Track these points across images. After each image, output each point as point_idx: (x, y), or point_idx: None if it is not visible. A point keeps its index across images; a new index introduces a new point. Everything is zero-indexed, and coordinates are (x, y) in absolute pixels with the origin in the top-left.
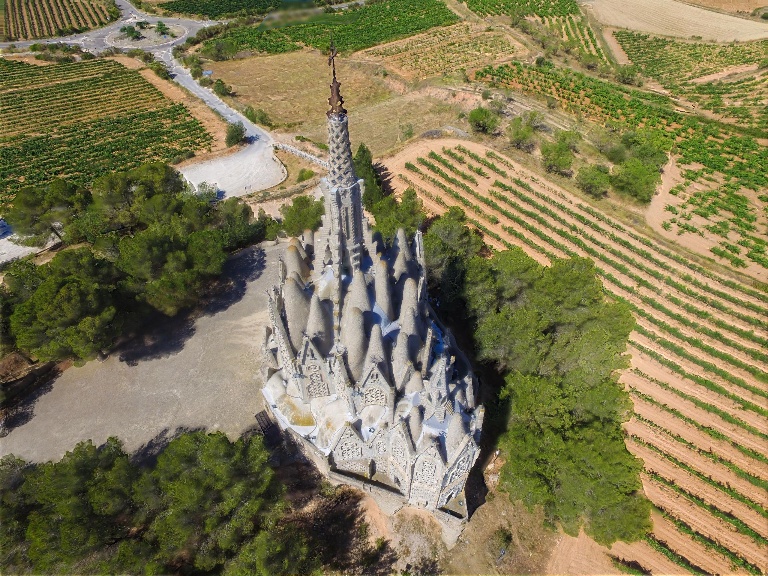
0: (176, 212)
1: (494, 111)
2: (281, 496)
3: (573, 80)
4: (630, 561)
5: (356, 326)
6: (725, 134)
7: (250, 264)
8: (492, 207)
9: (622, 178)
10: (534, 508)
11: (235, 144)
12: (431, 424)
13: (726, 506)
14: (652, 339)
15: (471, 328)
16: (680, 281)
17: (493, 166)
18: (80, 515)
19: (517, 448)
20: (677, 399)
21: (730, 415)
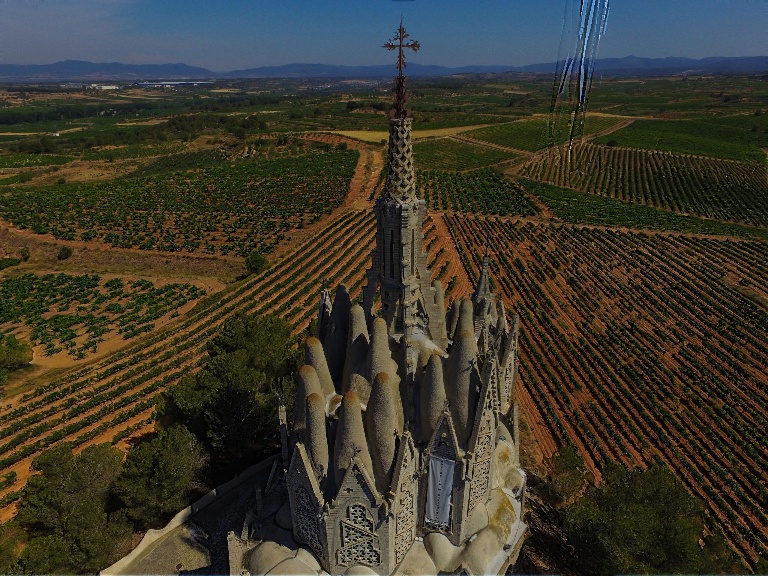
0: None
1: None
2: None
3: None
4: None
5: None
6: None
7: None
8: None
9: None
10: None
11: None
12: None
13: None
14: None
15: None
16: None
17: None
18: None
19: None
20: None
21: None
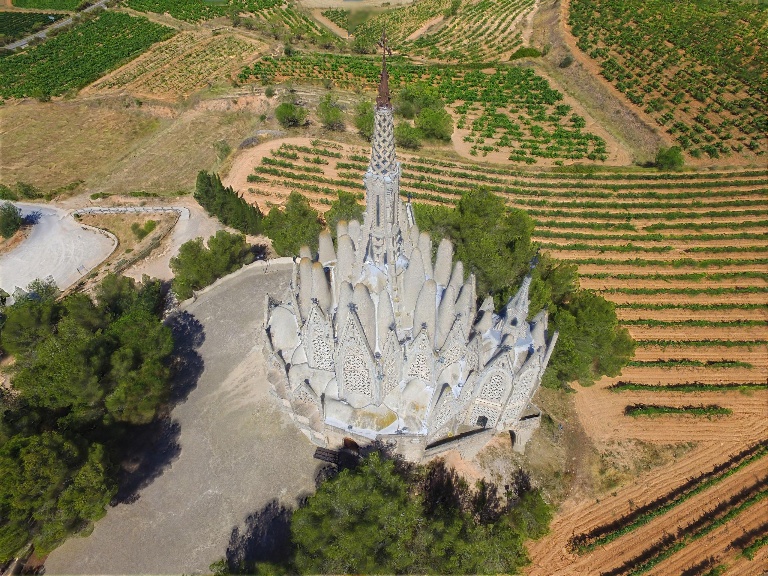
0: (53, 319)
1: None
2: (411, 494)
3: (326, 61)
4: (617, 384)
5: (433, 297)
6: (460, 73)
7: (183, 332)
8: (350, 186)
9: (426, 127)
10: (556, 385)
11: (16, 231)
12: (520, 344)
13: (636, 316)
14: None
15: None
16: (513, 187)
17: (326, 152)
18: None
19: None
20: None
21: (601, 259)
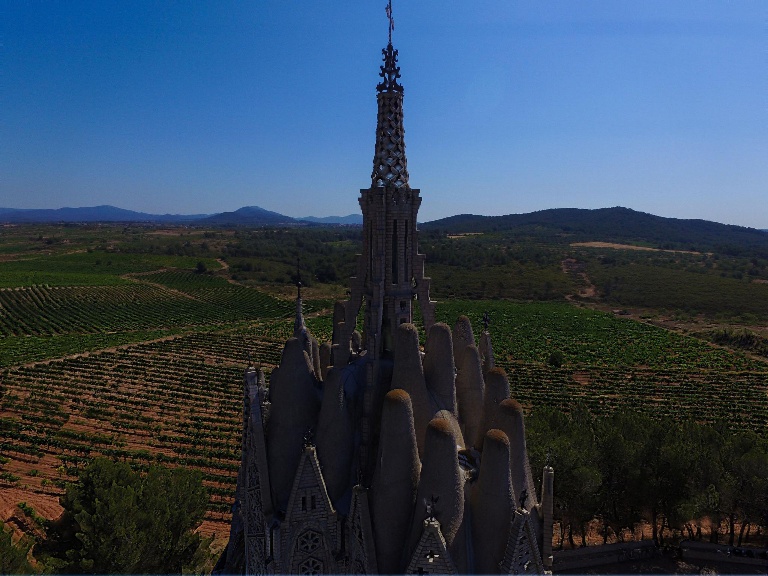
0: None
1: None
2: None
3: None
4: None
5: None
6: None
7: None
8: None
9: None
10: None
11: None
12: None
13: None
14: None
15: None
16: None
17: None
18: None
19: None
20: None
21: None
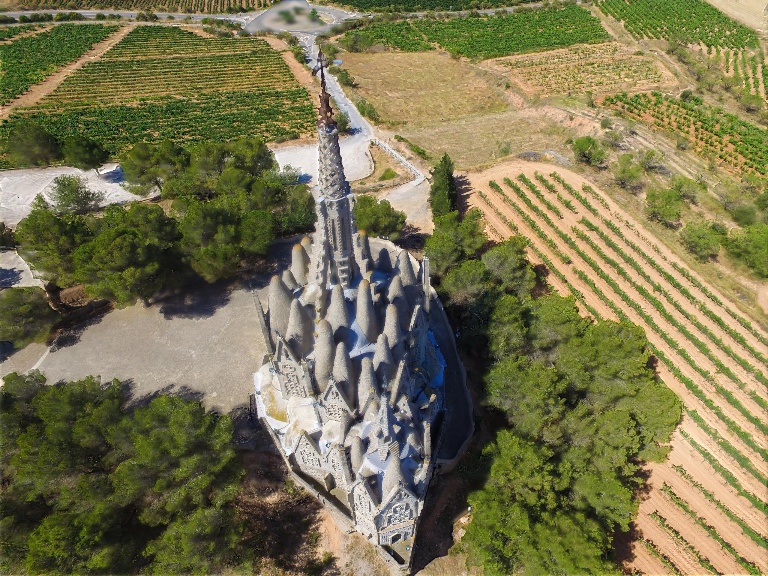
0: (248, 188)
1: (608, 142)
2: (237, 480)
3: (720, 122)
4: None
5: (323, 339)
6: None
7: None
8: (569, 245)
9: (740, 244)
10: None
11: None
12: (372, 459)
13: None
14: (713, 438)
15: (495, 368)
16: None
17: (585, 201)
18: (64, 440)
19: (481, 512)
20: (721, 516)
21: None
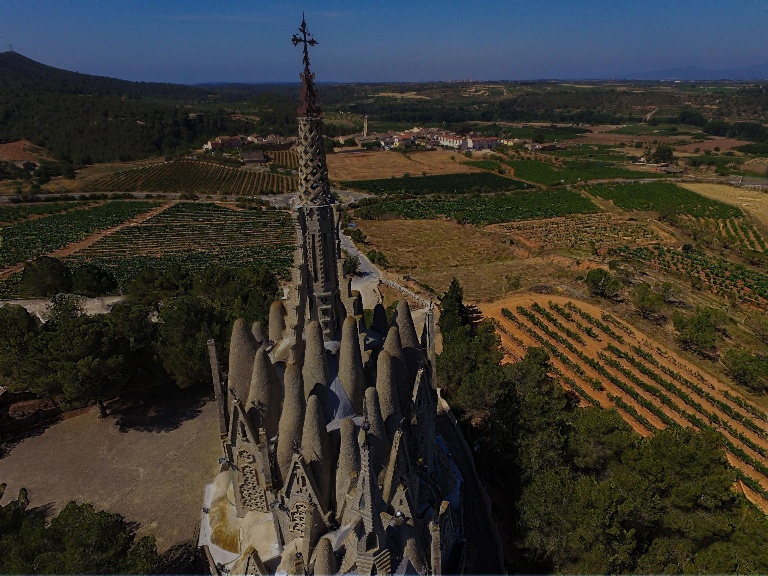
0: (245, 300)
1: (620, 279)
2: None
3: (729, 269)
4: None
5: (290, 393)
6: None
7: None
8: (598, 371)
9: None
10: None
11: None
12: None
13: None
14: None
15: None
16: None
17: (607, 328)
18: None
19: None
20: None
21: None
